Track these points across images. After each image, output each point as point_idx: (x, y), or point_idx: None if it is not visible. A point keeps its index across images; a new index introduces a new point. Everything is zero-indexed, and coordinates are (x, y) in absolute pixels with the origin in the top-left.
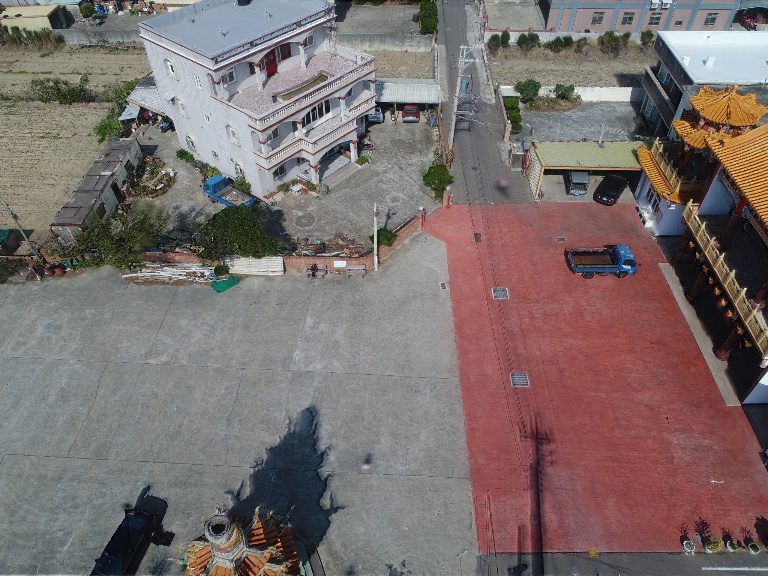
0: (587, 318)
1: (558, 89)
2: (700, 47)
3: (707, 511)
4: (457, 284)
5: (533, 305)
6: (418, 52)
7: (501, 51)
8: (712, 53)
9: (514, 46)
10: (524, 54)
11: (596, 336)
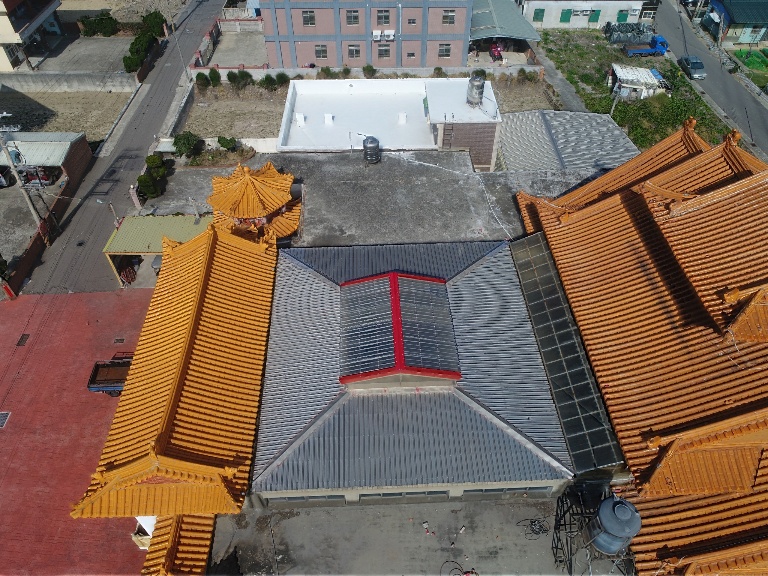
0: (78, 455)
1: (219, 142)
2: (340, 98)
3: None
4: None
5: (25, 437)
6: (124, 92)
7: (210, 91)
8: (347, 106)
9: (226, 84)
10: (236, 93)
11: (72, 481)
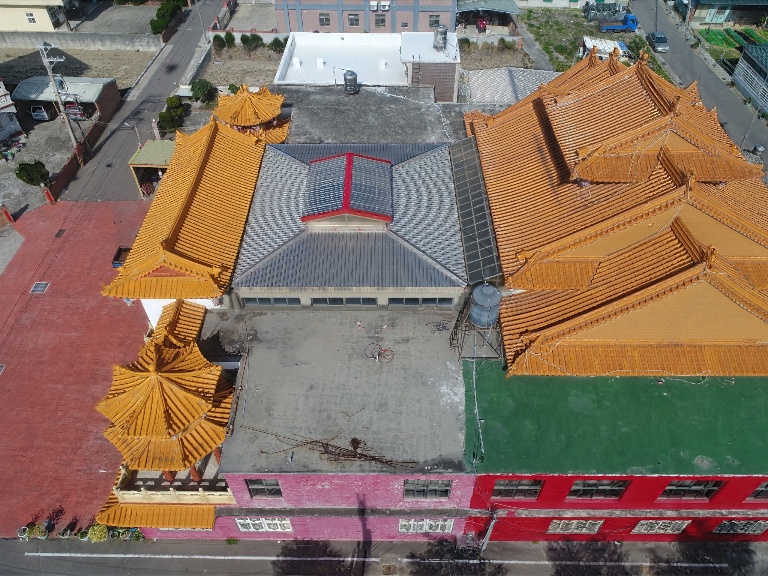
0: (103, 313)
1: (229, 89)
2: (332, 48)
3: (73, 499)
4: (5, 278)
5: (62, 299)
6: (150, 52)
7: (225, 51)
8: (338, 54)
9: (240, 46)
10: (248, 54)
11: (98, 330)
